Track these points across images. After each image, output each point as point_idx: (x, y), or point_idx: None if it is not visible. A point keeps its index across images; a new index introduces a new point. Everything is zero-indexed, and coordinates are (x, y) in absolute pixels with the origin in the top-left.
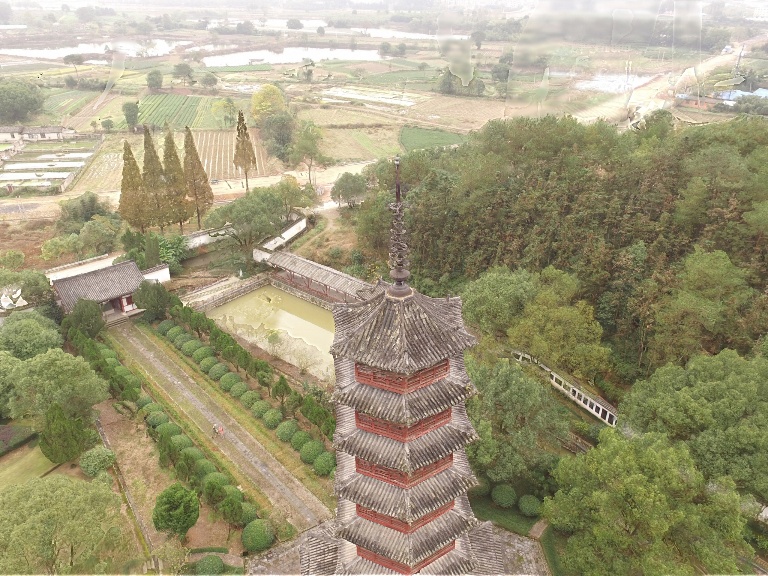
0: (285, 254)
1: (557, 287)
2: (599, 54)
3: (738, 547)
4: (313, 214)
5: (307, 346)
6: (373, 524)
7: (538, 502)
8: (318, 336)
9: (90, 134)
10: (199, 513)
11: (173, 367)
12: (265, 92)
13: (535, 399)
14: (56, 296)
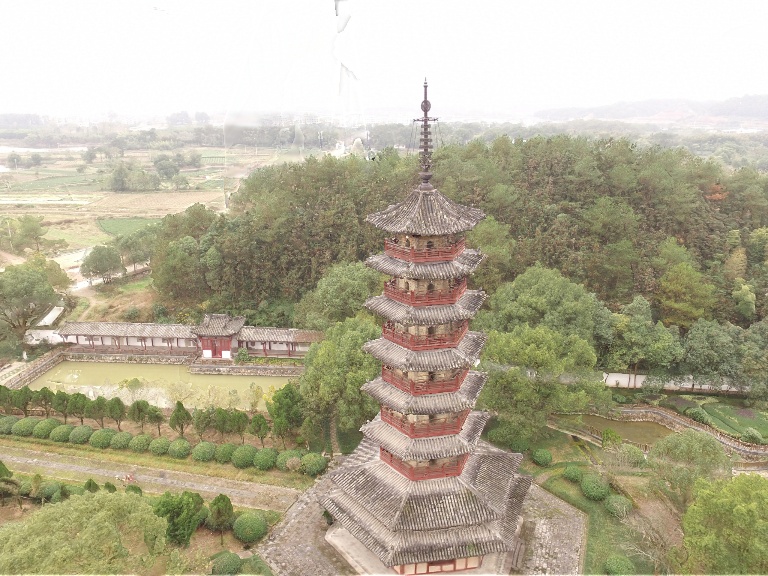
0: (79, 322)
1: None
2: None
3: (595, 376)
4: (64, 296)
5: None
6: (426, 398)
7: None
8: None
9: None
10: None
11: (13, 451)
12: None
13: None
14: None
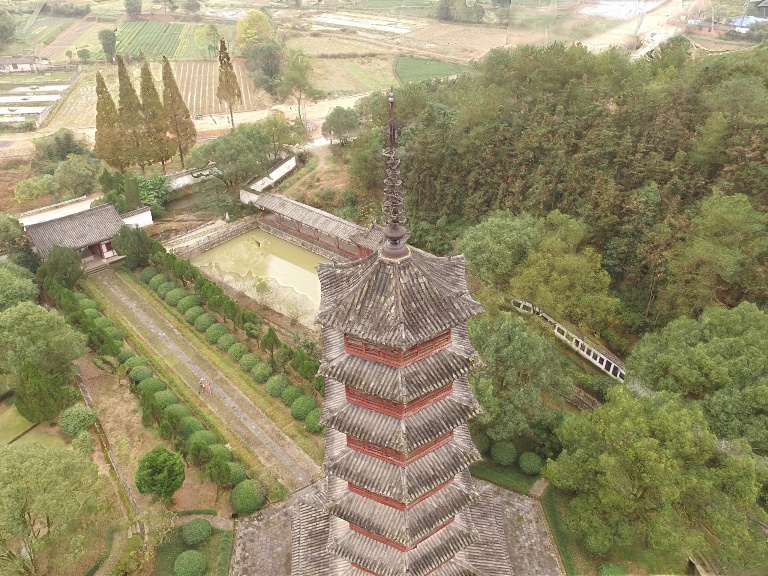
0: (273, 196)
1: (563, 233)
2: None
3: (750, 511)
4: (303, 152)
5: (297, 295)
6: (366, 499)
7: (539, 460)
8: (310, 282)
9: (65, 65)
10: (186, 473)
11: (157, 317)
12: (251, 18)
13: (539, 355)
14: (31, 242)
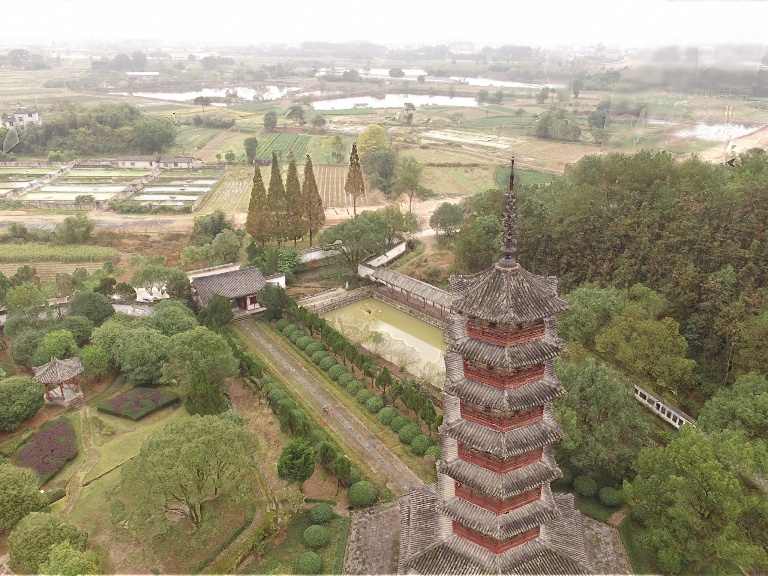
0: (388, 270)
1: (644, 303)
2: (698, 99)
3: None
4: (412, 239)
5: (407, 347)
6: (471, 466)
7: None
8: (414, 345)
9: (215, 164)
10: None
11: (289, 357)
12: (371, 131)
13: (619, 396)
14: (193, 292)
